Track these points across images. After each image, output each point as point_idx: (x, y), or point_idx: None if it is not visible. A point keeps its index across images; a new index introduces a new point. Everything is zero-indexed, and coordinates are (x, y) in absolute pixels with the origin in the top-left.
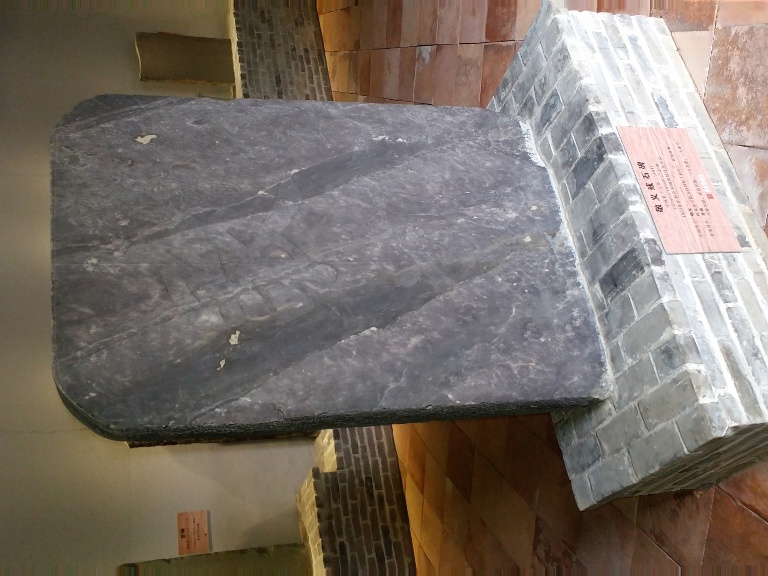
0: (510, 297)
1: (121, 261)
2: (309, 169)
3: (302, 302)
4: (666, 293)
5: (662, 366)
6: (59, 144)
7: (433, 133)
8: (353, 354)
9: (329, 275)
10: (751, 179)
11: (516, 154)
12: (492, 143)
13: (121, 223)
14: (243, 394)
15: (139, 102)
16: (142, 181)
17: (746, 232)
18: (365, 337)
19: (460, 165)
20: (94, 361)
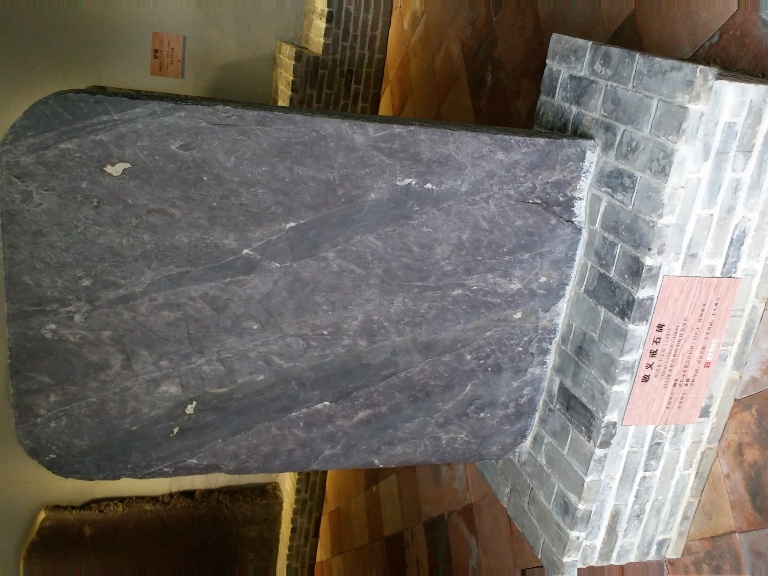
0: (471, 375)
1: (82, 328)
2: (308, 223)
3: (264, 375)
4: (593, 473)
5: (558, 505)
6: (7, 172)
7: (472, 176)
8: (300, 425)
9: (298, 348)
10: (760, 358)
11: (559, 201)
12: (537, 189)
13: (83, 283)
14: (191, 457)
15: (111, 110)
16: (109, 230)
17: (716, 401)
18: (316, 411)
19: (486, 223)
20: (54, 427)
